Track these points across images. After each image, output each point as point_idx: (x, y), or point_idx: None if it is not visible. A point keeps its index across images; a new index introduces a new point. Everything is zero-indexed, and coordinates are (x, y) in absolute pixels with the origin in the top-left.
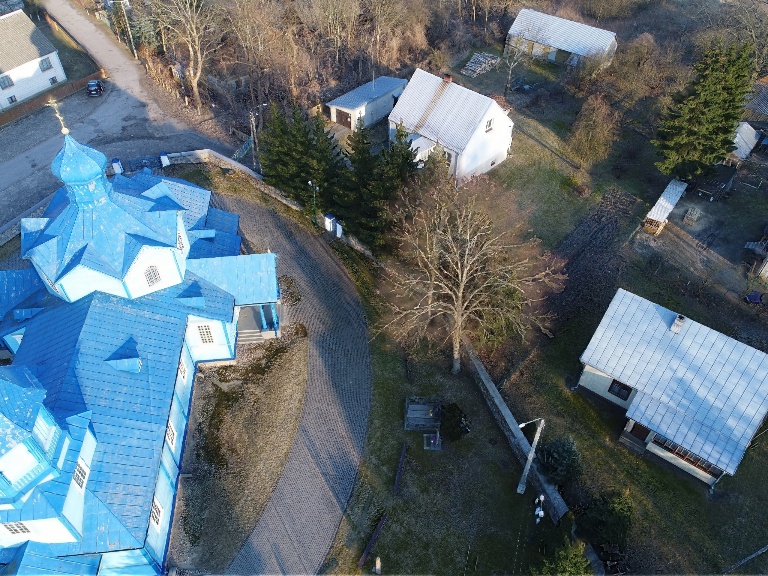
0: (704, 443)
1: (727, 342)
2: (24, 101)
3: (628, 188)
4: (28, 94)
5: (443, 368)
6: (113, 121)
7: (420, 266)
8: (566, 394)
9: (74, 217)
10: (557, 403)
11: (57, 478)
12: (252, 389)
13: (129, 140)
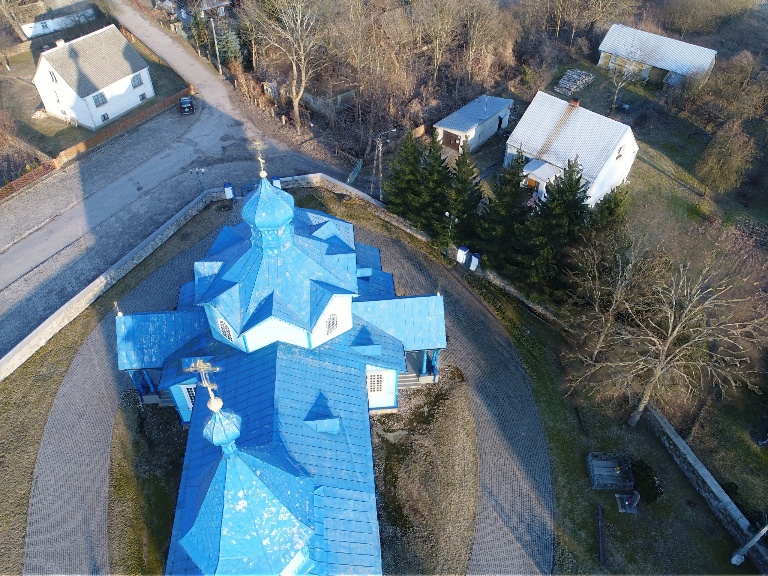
0: None
1: None
2: (115, 118)
3: (760, 218)
4: (119, 111)
5: (617, 419)
6: (211, 141)
7: (597, 311)
8: (755, 449)
9: (258, 263)
10: (748, 460)
11: (312, 570)
12: (421, 441)
13: (232, 162)
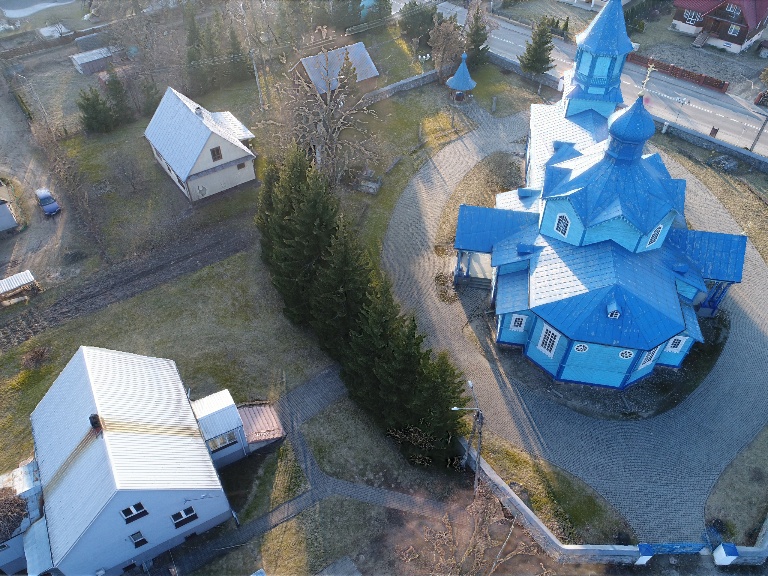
0: (229, 119)
1: (185, 102)
2: None
3: None
4: None
5: None
6: None
7: None
8: None
9: None
10: None
11: None
12: None
13: None
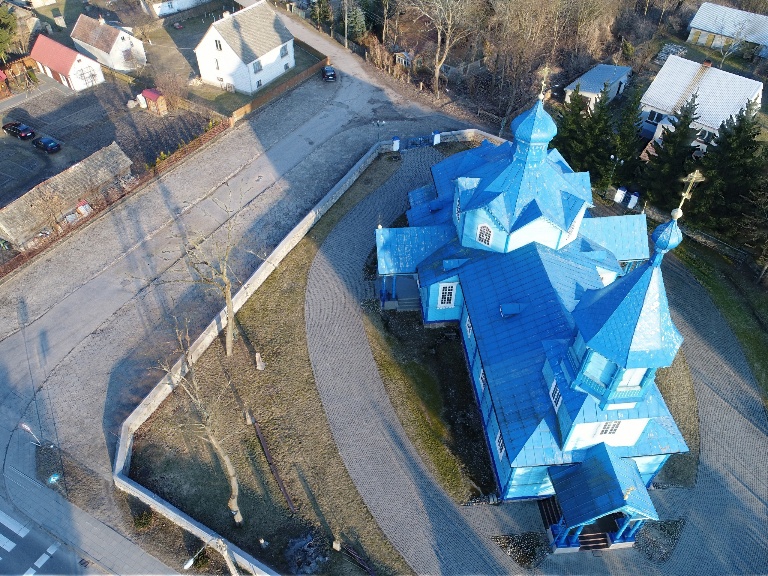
0: None
1: None
2: (266, 85)
3: None
4: (269, 79)
5: None
6: (360, 104)
7: None
8: None
9: (520, 175)
10: None
11: None
12: None
13: (385, 121)
